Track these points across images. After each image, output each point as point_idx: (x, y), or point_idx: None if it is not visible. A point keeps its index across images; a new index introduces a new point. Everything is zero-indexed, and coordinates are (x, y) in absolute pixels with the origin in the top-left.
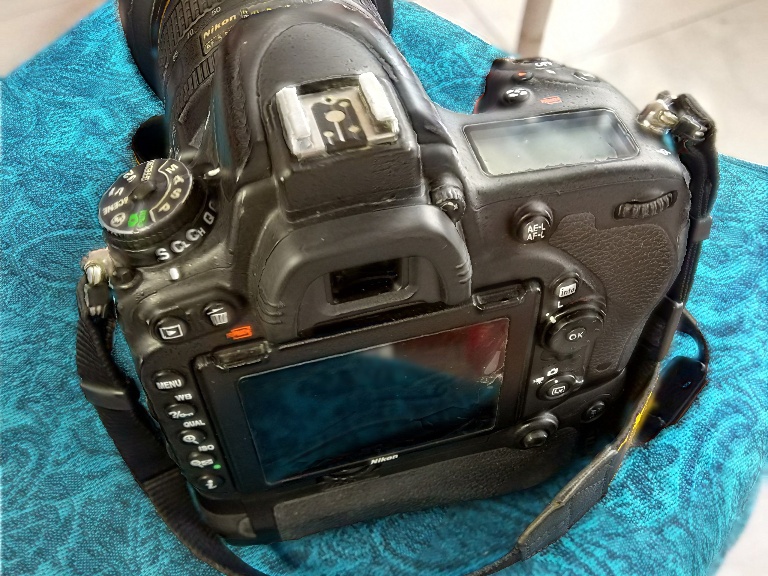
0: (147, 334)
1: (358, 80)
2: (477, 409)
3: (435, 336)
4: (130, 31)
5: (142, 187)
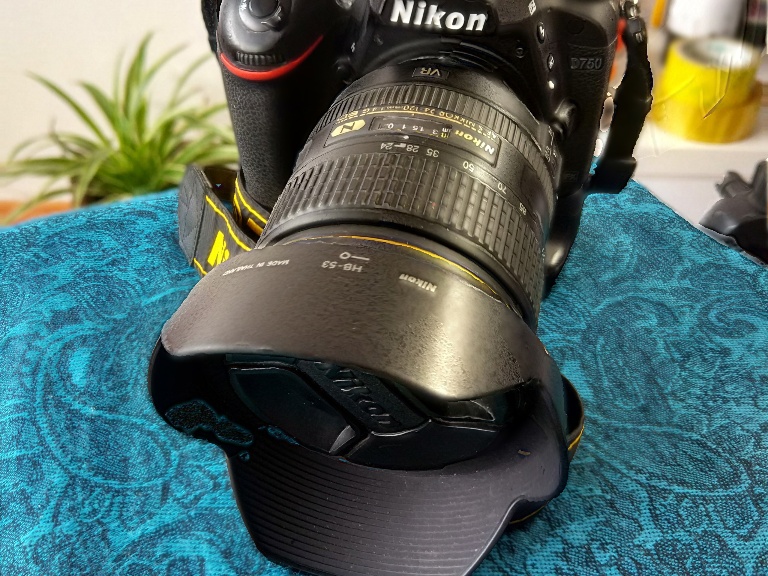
0: None
1: None
2: None
3: None
4: None
5: None
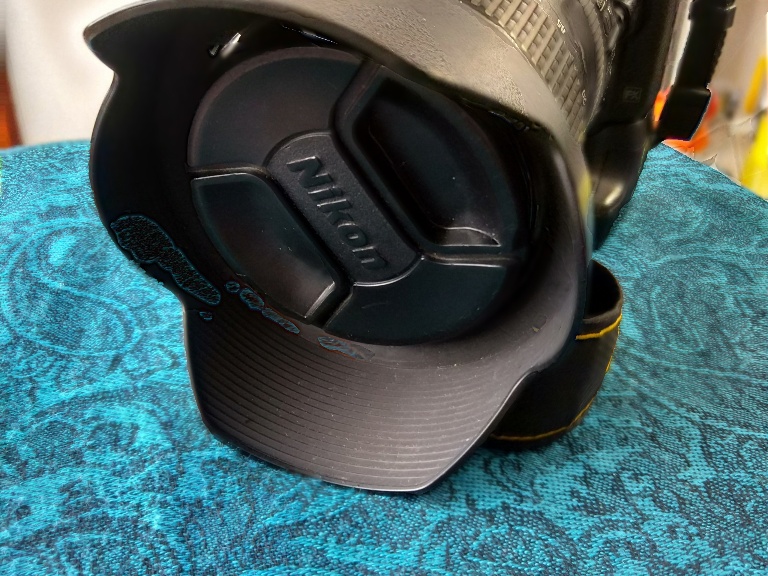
0: None
1: None
2: None
3: None
4: None
5: None
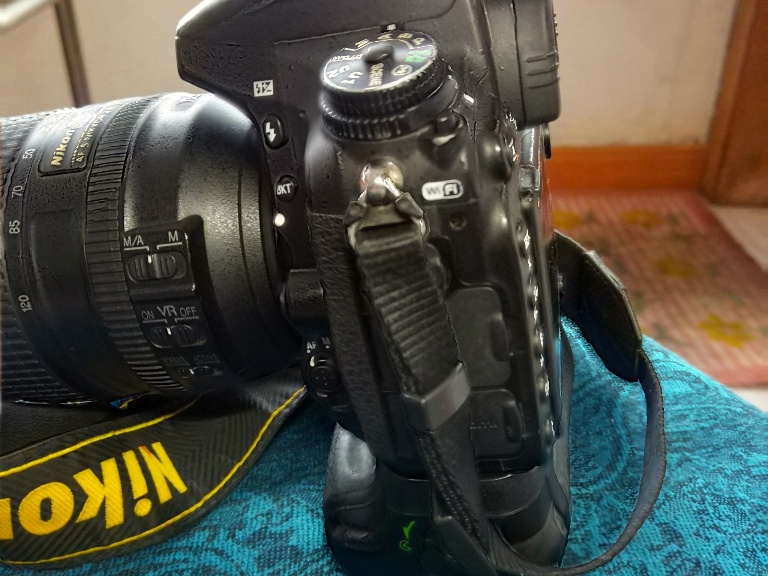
0: (492, 181)
1: None
2: (549, 251)
3: (541, 136)
4: None
5: (374, 52)
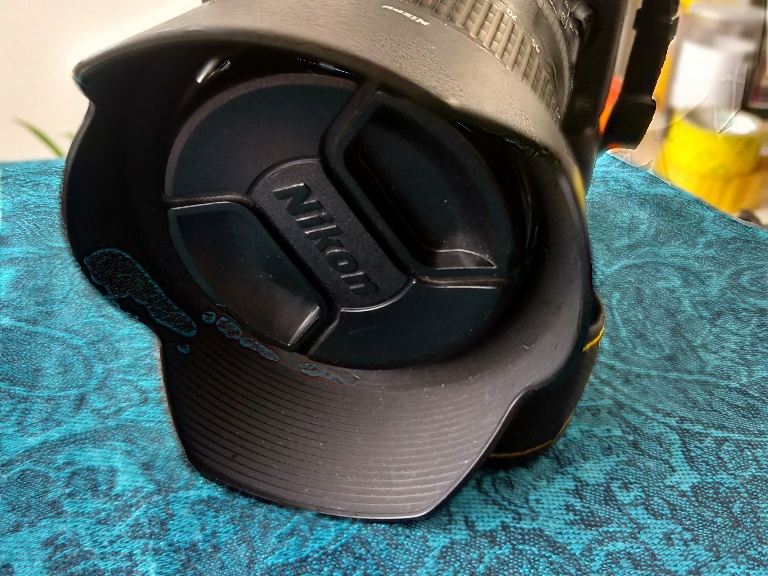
0: None
1: None
2: None
3: None
4: None
5: None
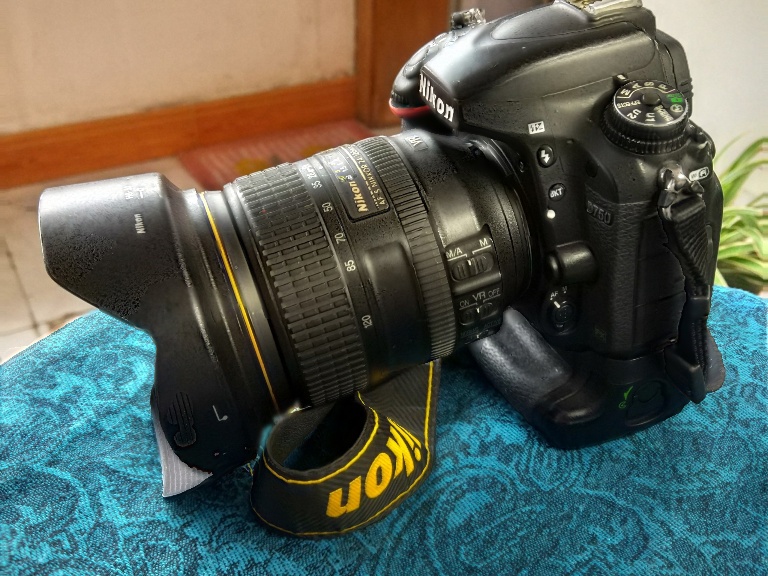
0: None
1: (565, 0)
2: None
3: None
4: (223, 389)
5: (649, 99)
